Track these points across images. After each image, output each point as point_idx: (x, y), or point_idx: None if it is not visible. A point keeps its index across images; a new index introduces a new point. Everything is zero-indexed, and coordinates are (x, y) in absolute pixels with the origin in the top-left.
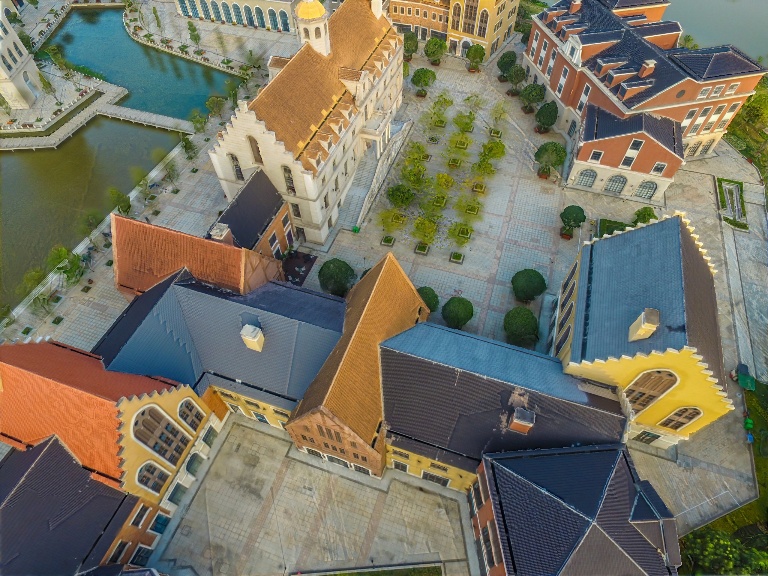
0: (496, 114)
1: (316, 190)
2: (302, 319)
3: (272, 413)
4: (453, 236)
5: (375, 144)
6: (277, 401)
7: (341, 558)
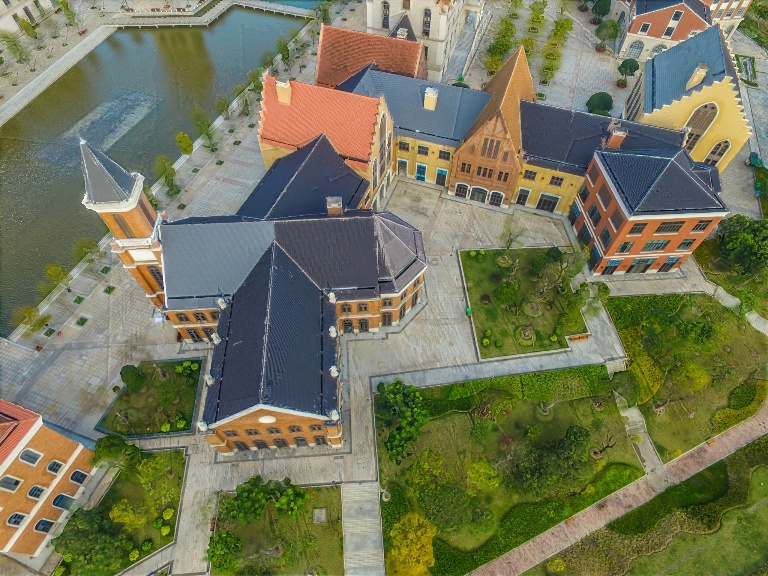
0: (558, 11)
1: (445, 32)
2: None
3: (436, 158)
4: (536, 84)
5: (475, 16)
6: (446, 142)
7: (489, 244)
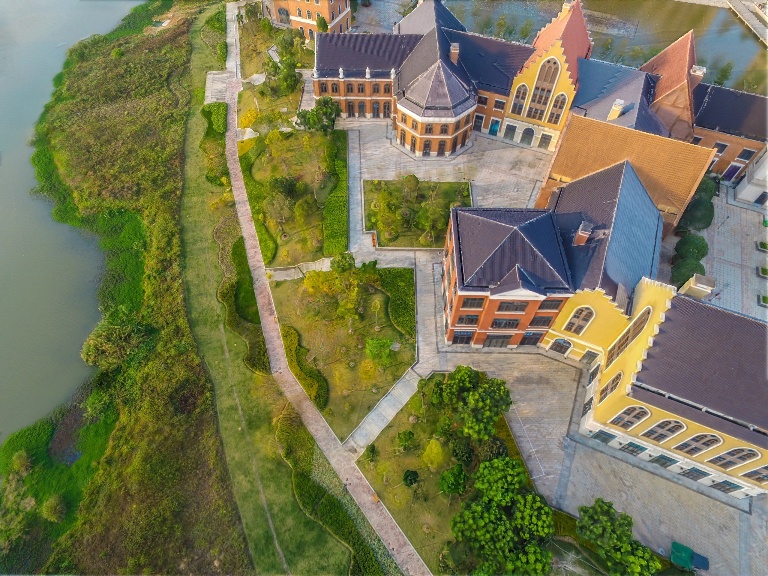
0: None
1: None
2: (637, 127)
3: None
4: None
5: None
6: None
7: (479, 204)
